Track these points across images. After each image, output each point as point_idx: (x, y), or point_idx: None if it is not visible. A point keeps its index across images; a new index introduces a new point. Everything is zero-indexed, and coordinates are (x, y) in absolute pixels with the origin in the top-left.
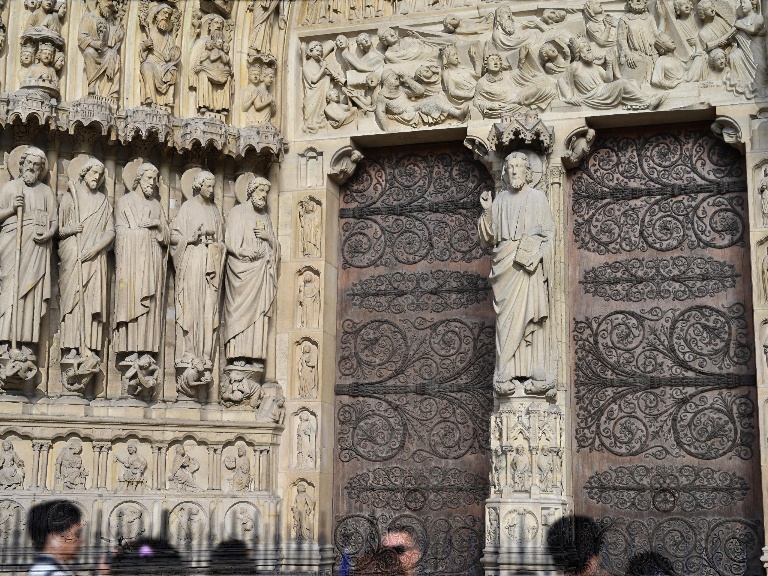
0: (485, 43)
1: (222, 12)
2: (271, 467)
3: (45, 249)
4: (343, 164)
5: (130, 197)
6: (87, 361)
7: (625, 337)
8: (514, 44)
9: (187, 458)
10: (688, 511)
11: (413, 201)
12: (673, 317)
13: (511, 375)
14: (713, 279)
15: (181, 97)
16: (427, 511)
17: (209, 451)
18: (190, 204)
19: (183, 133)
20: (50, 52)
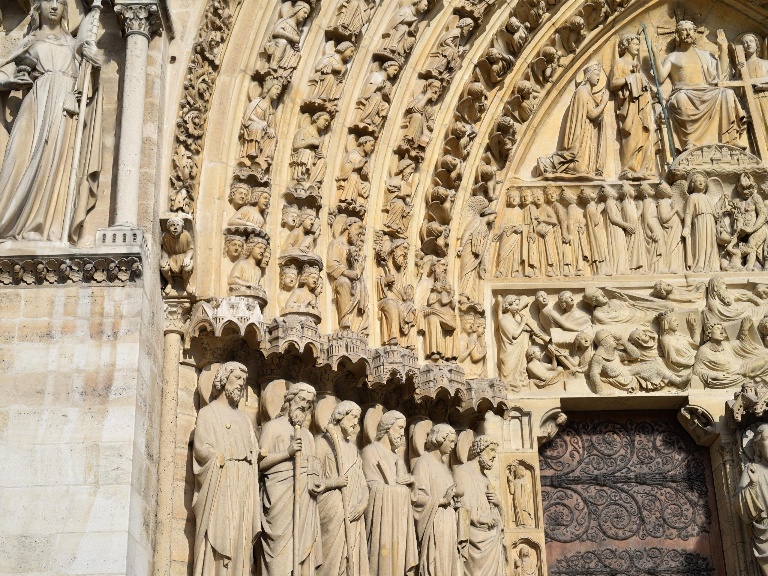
0: (701, 312)
1: (440, 254)
2: None
3: (316, 504)
4: (548, 427)
5: (379, 448)
6: None
7: None
8: (733, 315)
9: None
10: None
11: (616, 471)
12: None
13: None
14: None
15: None
16: None
17: None
18: (429, 460)
19: (423, 380)
20: (317, 276)
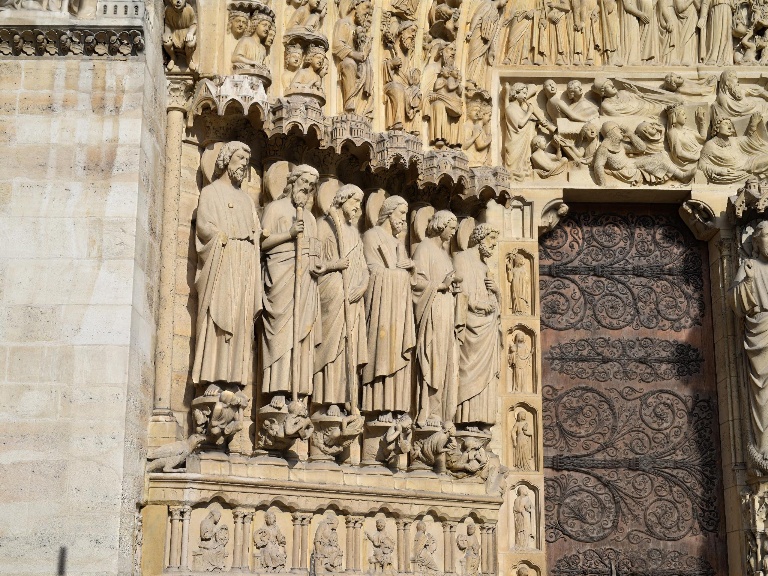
0: (711, 106)
1: (448, 38)
2: (497, 547)
3: (317, 285)
4: (549, 217)
5: (380, 232)
6: (358, 420)
7: None
8: (743, 110)
9: (429, 536)
10: None
11: (615, 263)
12: None
13: None
14: None
15: None
16: None
17: (445, 528)
18: (429, 246)
19: (426, 166)
20: (323, 57)
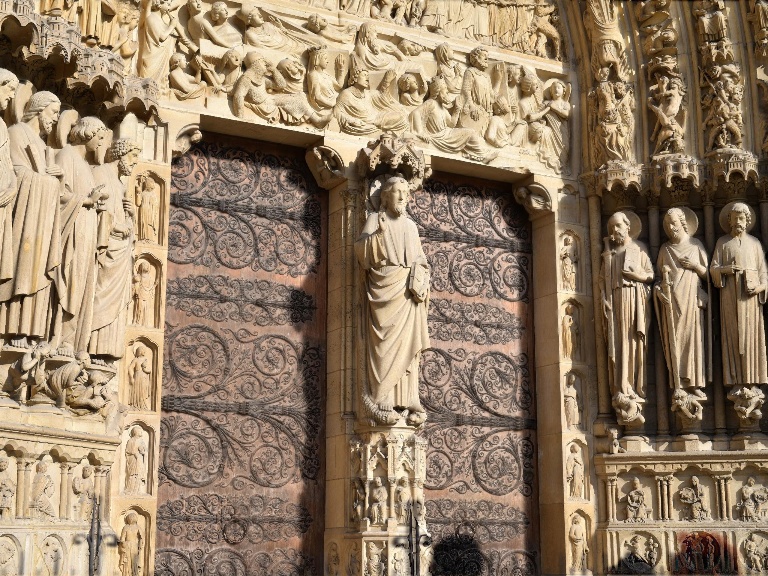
0: (350, 55)
1: None
2: (110, 492)
3: None
4: (182, 142)
5: (28, 130)
6: None
7: (436, 374)
8: (379, 65)
9: (49, 478)
10: (484, 543)
11: (239, 199)
12: (474, 359)
13: (393, 404)
14: (505, 329)
15: None
16: (247, 544)
17: (63, 470)
18: (73, 154)
19: None
20: None
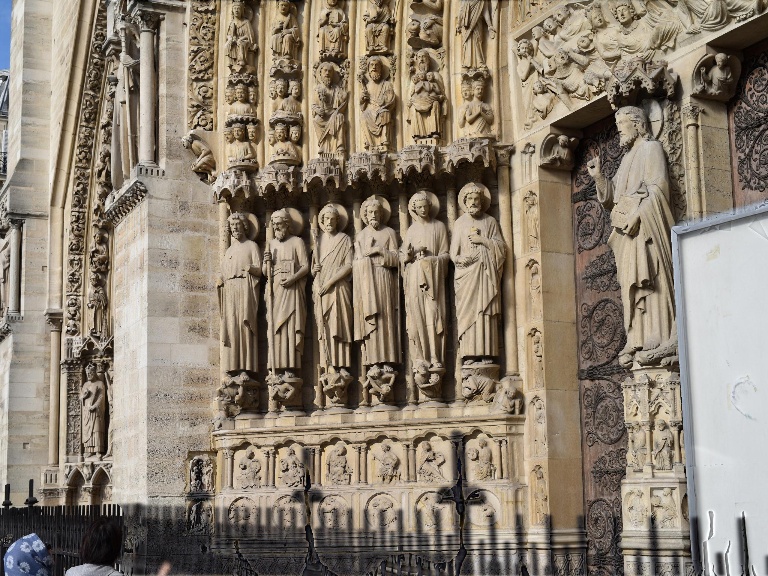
0: None
1: (431, 44)
2: (510, 456)
3: (294, 291)
4: (555, 152)
5: (363, 232)
6: (330, 378)
7: None
8: None
9: (431, 453)
10: None
11: None
12: None
13: (631, 347)
14: None
15: (404, 132)
16: None
17: (452, 445)
18: (413, 226)
19: None
20: (281, 130)
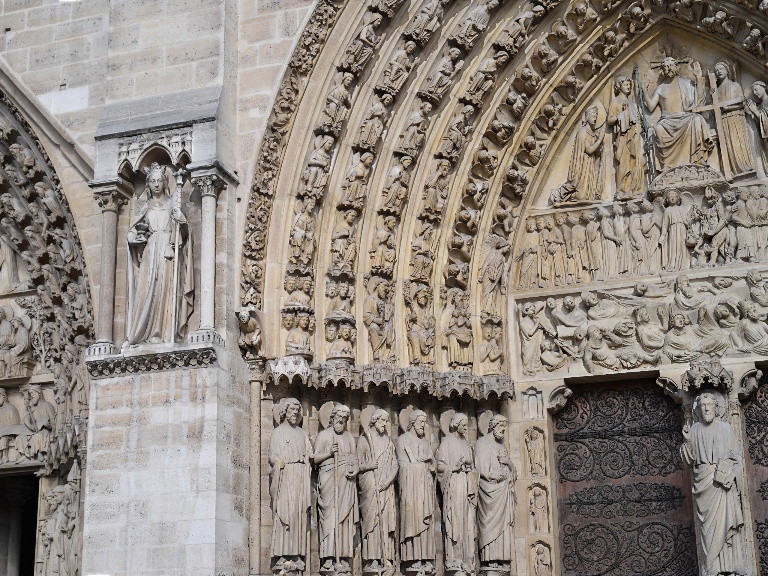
0: (669, 304)
1: (461, 286)
2: None
3: (353, 483)
4: (558, 399)
5: (407, 437)
6: (389, 570)
7: None
8: (693, 305)
9: None
10: None
11: (614, 427)
12: None
13: (718, 571)
14: None
15: (436, 355)
16: None
17: None
18: (450, 439)
19: (442, 384)
20: (349, 330)
